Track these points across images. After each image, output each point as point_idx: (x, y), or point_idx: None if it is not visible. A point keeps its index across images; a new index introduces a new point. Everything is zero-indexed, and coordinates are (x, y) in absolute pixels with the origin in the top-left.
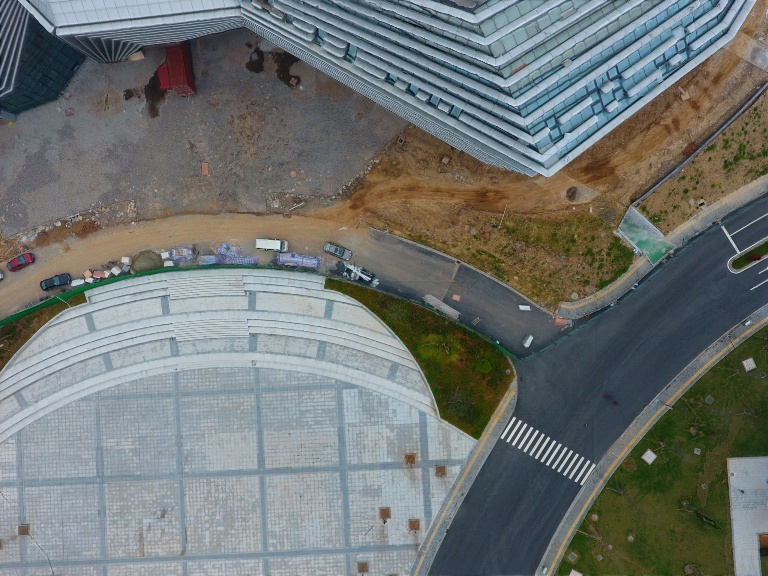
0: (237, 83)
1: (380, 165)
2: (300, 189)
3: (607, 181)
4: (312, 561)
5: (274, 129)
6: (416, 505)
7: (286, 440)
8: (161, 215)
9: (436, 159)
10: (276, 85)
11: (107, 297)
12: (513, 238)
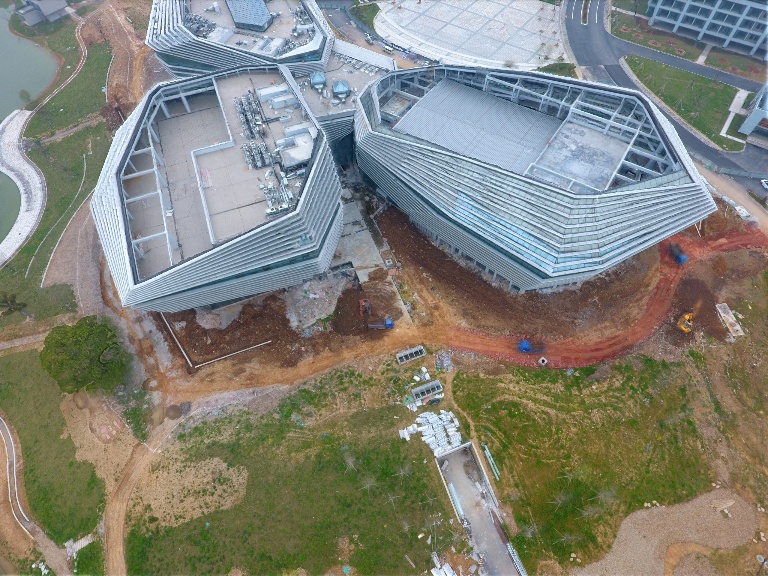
0: None
1: None
2: None
3: None
4: (452, 4)
5: None
6: (408, 1)
7: (433, 25)
8: None
9: None
10: None
11: None
12: None
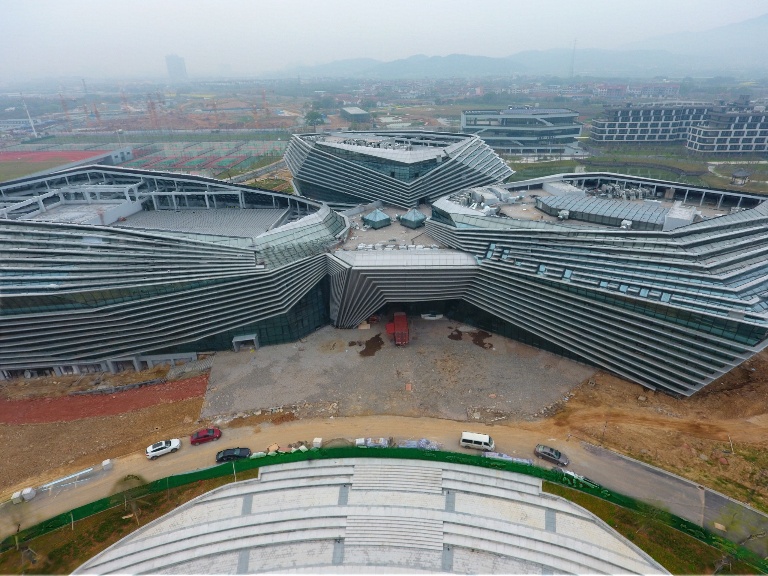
0: (441, 344)
1: (577, 397)
2: (501, 407)
3: None
4: None
5: (472, 369)
6: None
7: None
8: (361, 414)
9: (632, 397)
10: (473, 347)
11: (281, 477)
12: (757, 466)
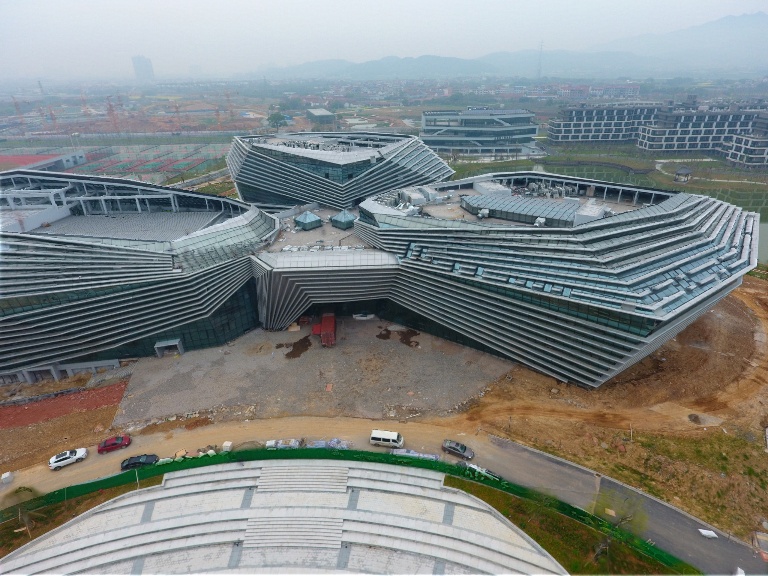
0: (368, 344)
1: (493, 392)
2: (417, 404)
3: (725, 412)
4: None
5: (395, 367)
6: None
7: None
8: (277, 416)
9: (545, 390)
10: (399, 345)
11: (186, 482)
12: (652, 452)
